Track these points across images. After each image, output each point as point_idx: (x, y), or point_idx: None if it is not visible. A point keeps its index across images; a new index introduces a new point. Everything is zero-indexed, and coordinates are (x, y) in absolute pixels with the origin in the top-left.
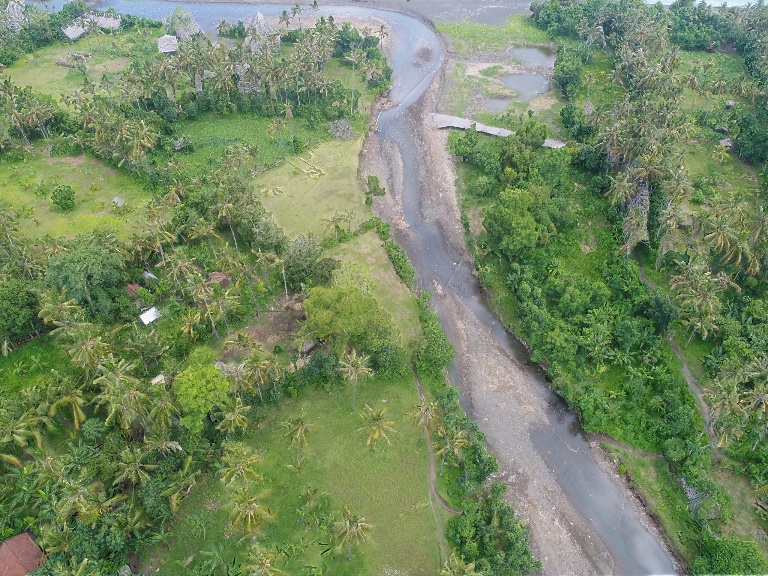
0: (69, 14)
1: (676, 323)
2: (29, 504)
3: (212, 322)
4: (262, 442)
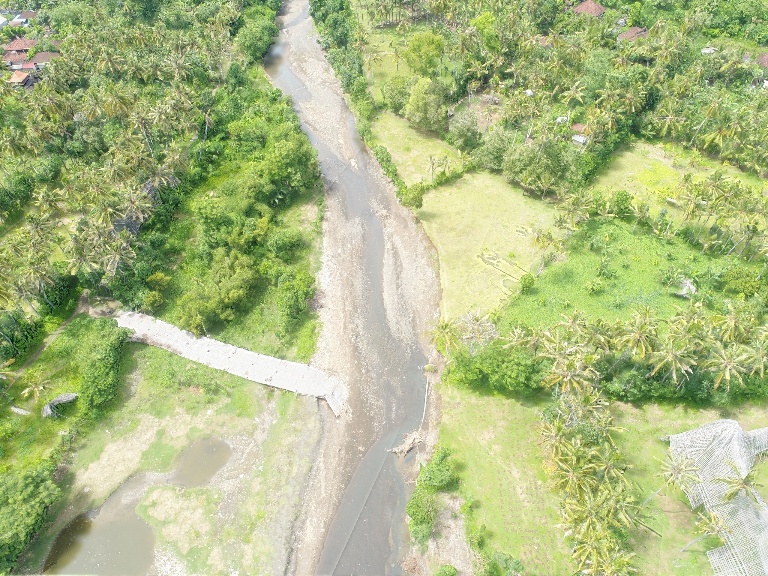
0: None
1: (186, 137)
2: (550, 48)
3: None
4: None
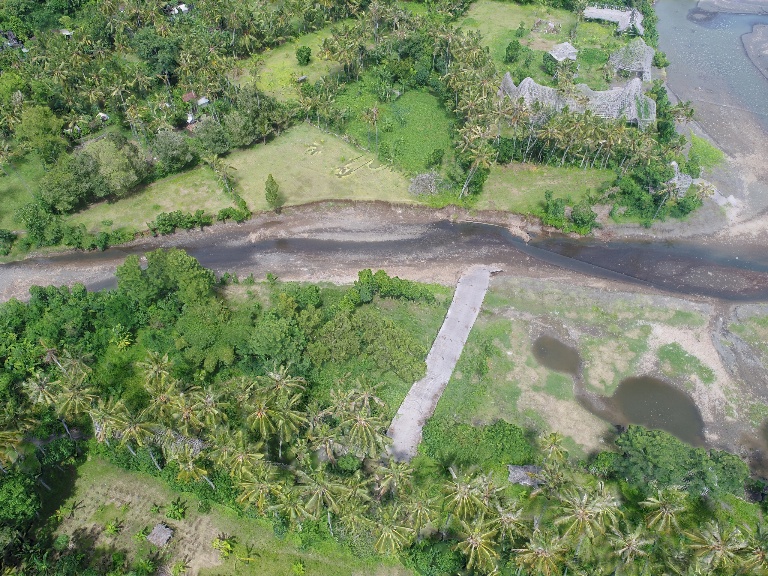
0: (620, 1)
1: None
2: None
3: (130, 122)
4: (35, 161)
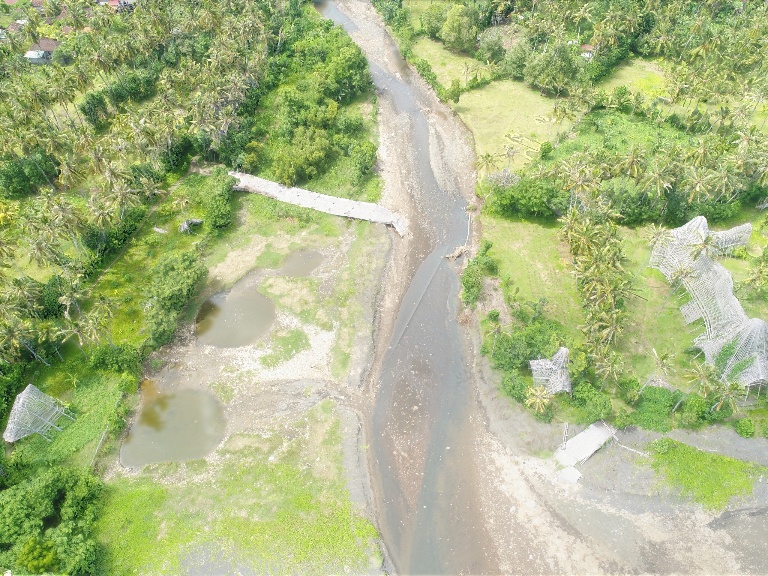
0: None
1: None
2: None
3: None
4: None
